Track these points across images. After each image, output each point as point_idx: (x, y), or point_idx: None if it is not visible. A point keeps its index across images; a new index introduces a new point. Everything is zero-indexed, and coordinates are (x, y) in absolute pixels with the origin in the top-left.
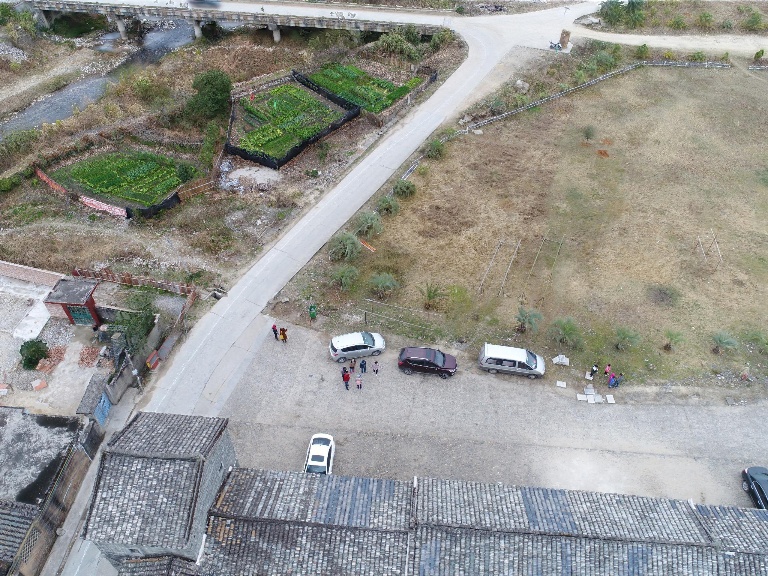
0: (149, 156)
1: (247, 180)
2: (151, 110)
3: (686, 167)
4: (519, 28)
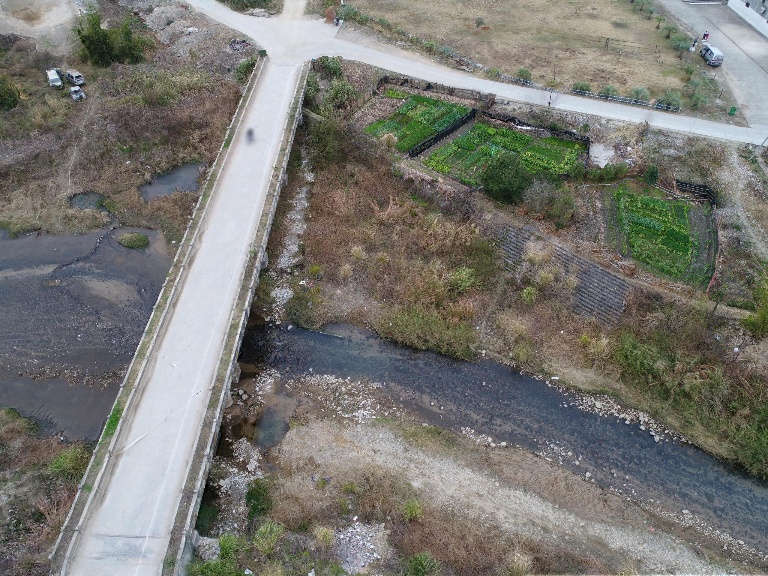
0: None
1: (614, 160)
2: (541, 238)
3: (489, 8)
4: (294, 35)
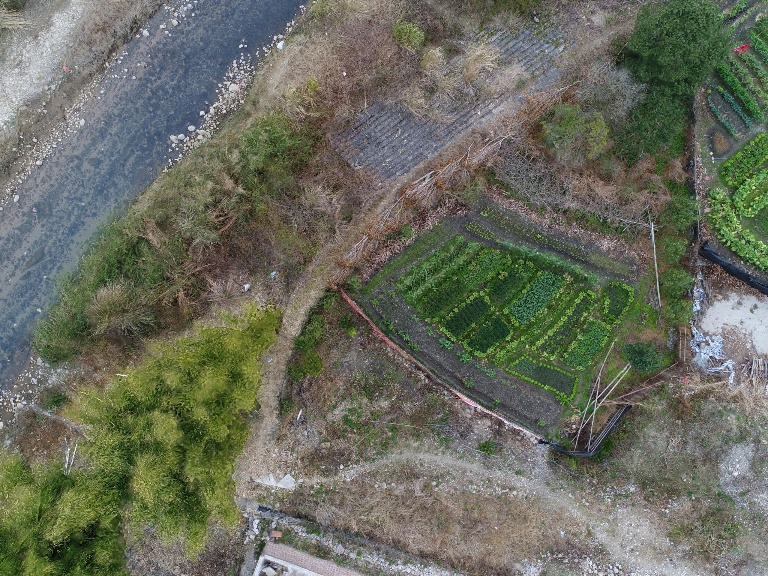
0: (546, 259)
1: (738, 340)
2: None
3: None
4: None
